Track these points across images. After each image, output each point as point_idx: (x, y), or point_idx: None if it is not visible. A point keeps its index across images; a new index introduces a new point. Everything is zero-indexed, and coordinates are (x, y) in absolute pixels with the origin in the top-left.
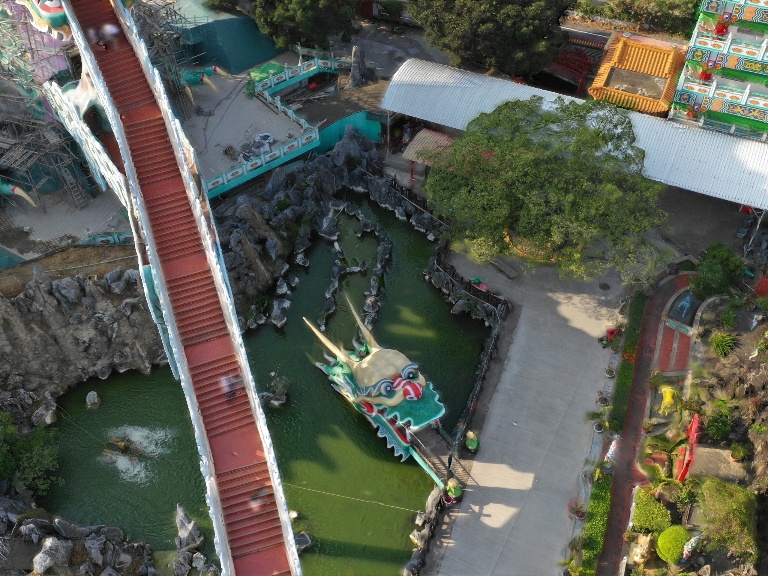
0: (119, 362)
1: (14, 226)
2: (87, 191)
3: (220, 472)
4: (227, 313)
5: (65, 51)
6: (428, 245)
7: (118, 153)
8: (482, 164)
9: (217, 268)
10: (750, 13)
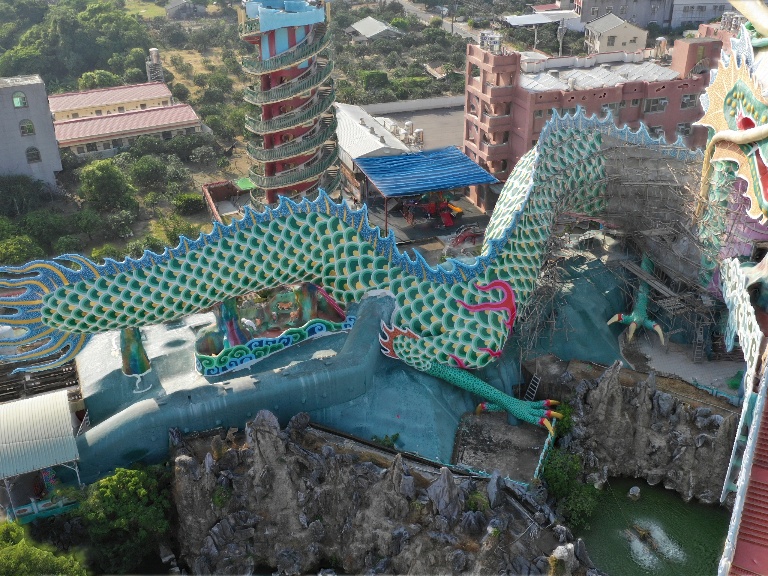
0: (671, 477)
1: (640, 351)
2: (706, 354)
3: (736, 565)
4: None
5: (756, 242)
6: None
7: (761, 322)
8: None
9: None
10: None
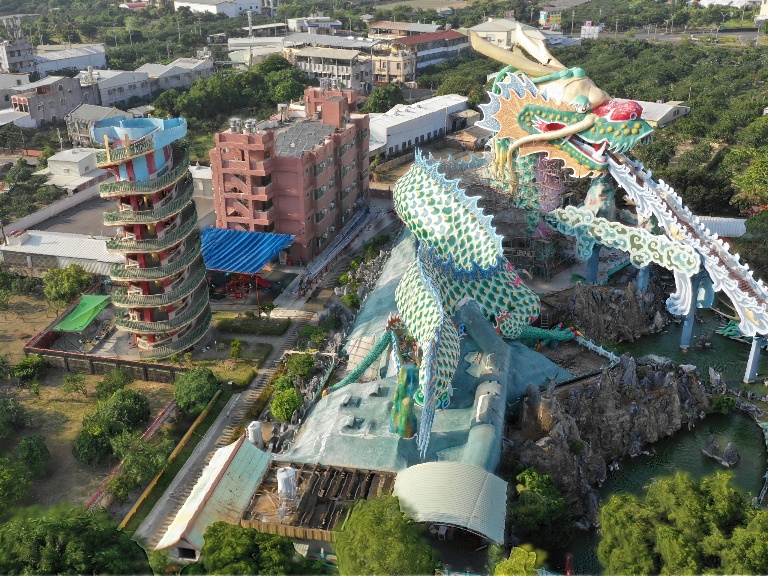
0: None
1: None
2: None
3: None
4: (733, 262)
5: (563, 195)
6: (722, 293)
7: None
8: (766, 233)
9: (725, 244)
10: None
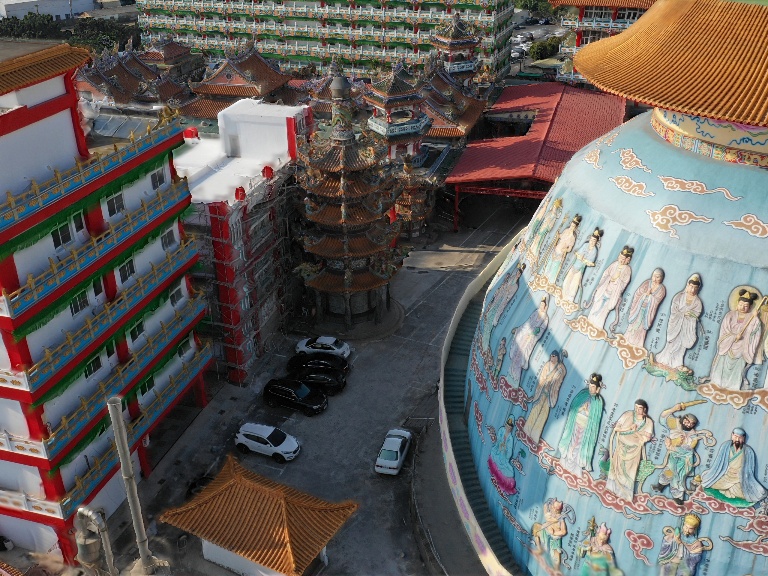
0: None
1: None
2: None
3: None
4: None
5: None
6: None
7: None
8: None
9: None
10: (149, 6)
